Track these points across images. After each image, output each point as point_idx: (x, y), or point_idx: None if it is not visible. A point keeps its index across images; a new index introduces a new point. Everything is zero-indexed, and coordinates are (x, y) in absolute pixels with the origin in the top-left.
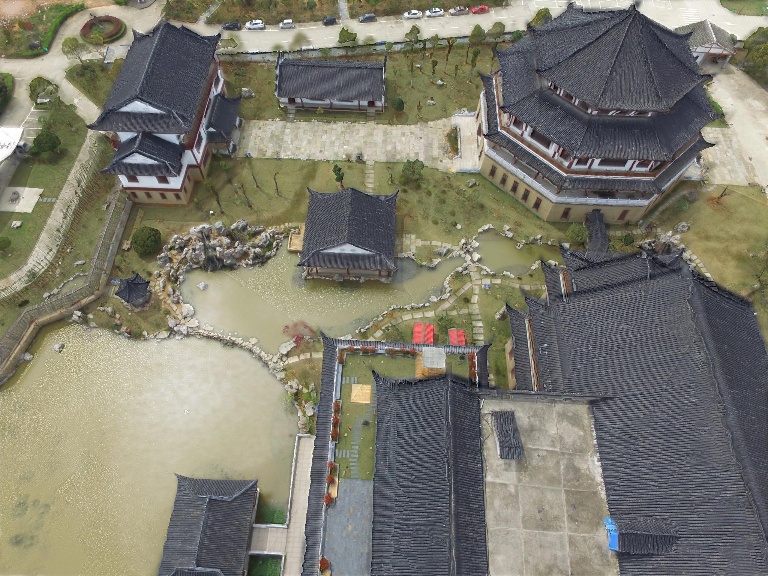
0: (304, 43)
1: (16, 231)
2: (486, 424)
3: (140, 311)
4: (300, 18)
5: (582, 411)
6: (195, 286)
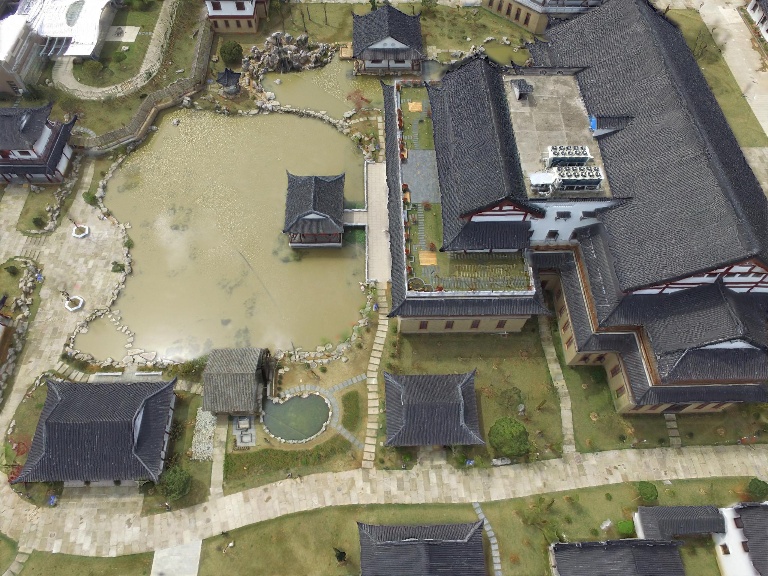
0: None
1: (126, 53)
2: (508, 86)
3: (234, 98)
4: None
5: (570, 79)
6: (272, 82)
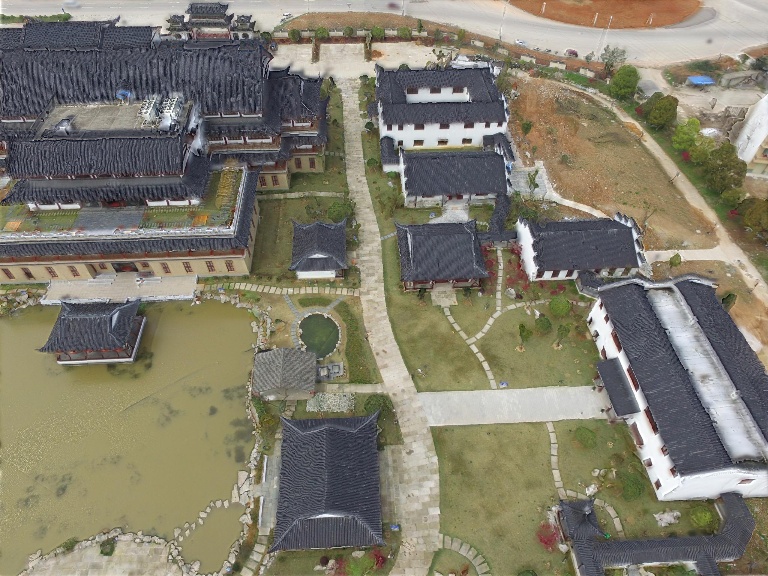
0: None
1: None
2: None
3: None
4: None
5: (57, 109)
6: None
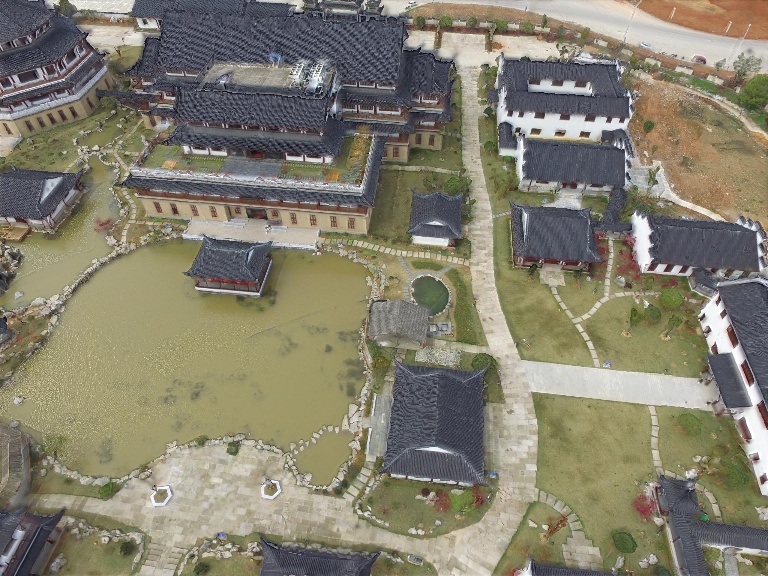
0: None
1: None
2: None
3: (17, 337)
4: None
5: (216, 67)
6: (15, 300)
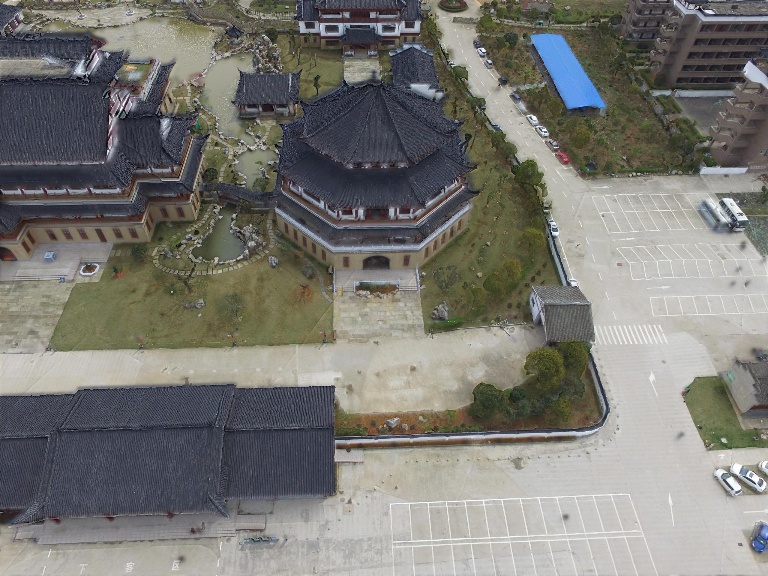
0: (471, 74)
1: (283, 8)
2: None
3: (229, 44)
4: (501, 69)
5: None
6: None
